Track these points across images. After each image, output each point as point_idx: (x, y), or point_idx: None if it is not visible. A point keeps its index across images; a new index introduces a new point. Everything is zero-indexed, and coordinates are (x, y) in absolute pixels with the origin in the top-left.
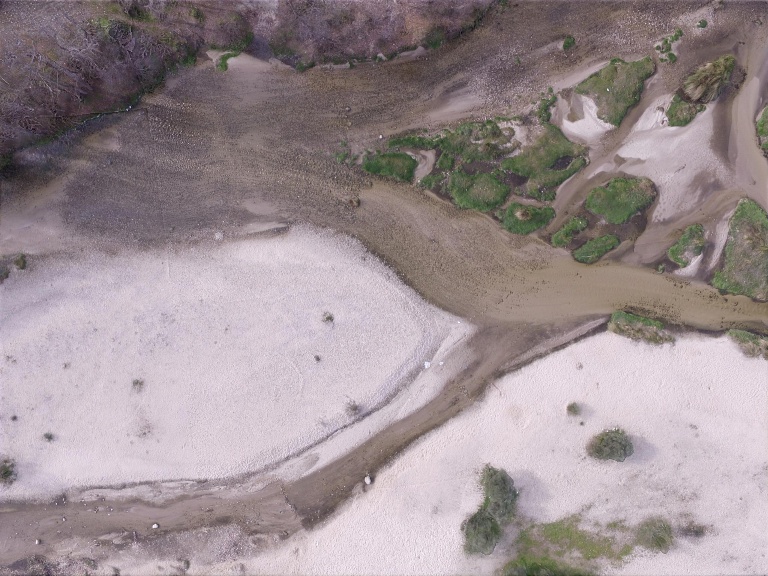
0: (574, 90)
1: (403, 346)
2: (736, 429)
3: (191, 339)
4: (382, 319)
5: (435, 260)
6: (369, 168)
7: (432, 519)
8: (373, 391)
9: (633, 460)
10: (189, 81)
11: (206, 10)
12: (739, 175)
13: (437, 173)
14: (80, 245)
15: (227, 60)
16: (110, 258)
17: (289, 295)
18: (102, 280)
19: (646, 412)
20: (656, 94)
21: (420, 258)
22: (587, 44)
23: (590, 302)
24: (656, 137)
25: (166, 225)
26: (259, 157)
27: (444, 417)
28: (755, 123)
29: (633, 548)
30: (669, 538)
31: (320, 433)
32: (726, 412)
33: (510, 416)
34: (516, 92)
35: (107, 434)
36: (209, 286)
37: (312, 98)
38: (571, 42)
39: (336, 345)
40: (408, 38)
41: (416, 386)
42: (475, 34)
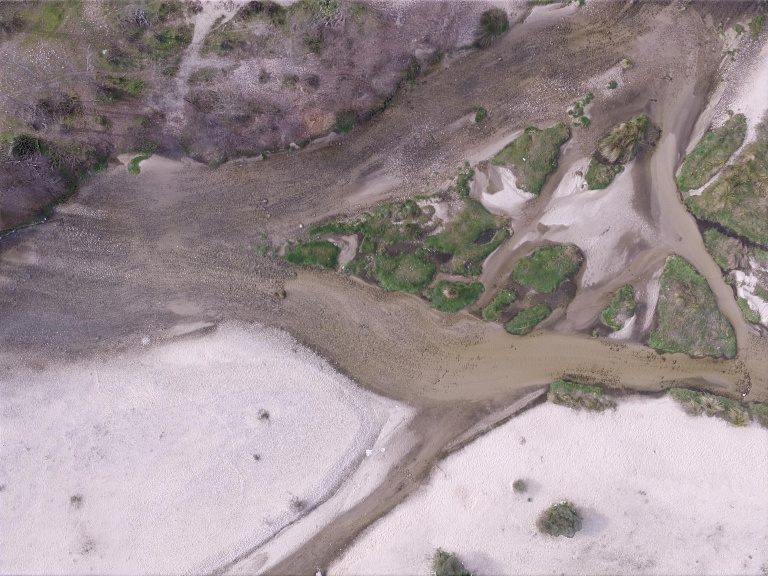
0: (491, 162)
1: (342, 437)
2: (685, 491)
3: (126, 450)
4: (318, 411)
5: (367, 345)
6: (292, 259)
7: None
8: (316, 485)
9: (584, 532)
10: (102, 188)
11: (112, 116)
12: (664, 232)
13: (361, 258)
14: (6, 363)
15: (139, 163)
16: (38, 374)
17: (222, 395)
18: (31, 397)
19: (593, 482)
20: (573, 159)
21: (352, 345)
22: (499, 115)
23: (527, 374)
24: (577, 202)
25: (92, 335)
26: (180, 257)
27: (391, 504)
28: (675, 179)
29: None
30: None
31: (266, 532)
32: (673, 475)
33: (457, 498)
34: (433, 169)
35: (49, 554)
36: (140, 394)
37: (228, 193)
38: (483, 114)
39: (274, 442)
40: (319, 125)
41: (359, 475)
42: (386, 115)
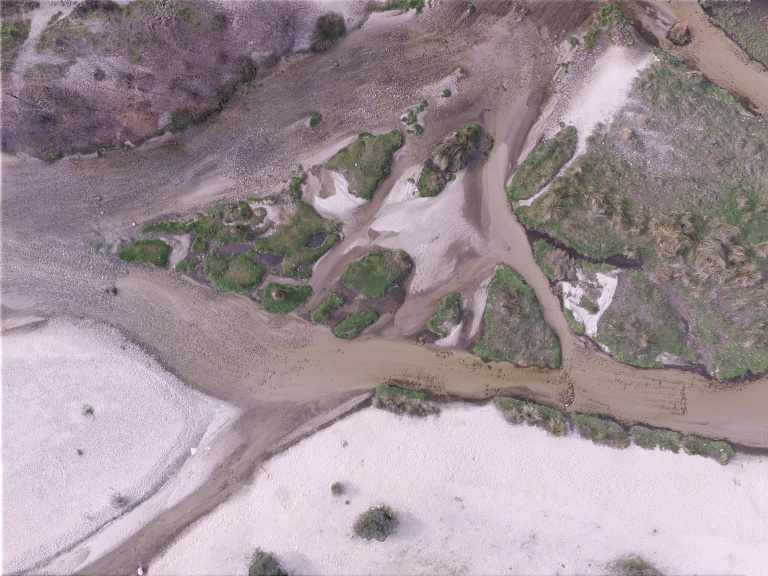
0: (324, 166)
1: (165, 434)
2: (501, 499)
3: None
4: (143, 408)
5: (196, 345)
6: (123, 257)
7: None
8: (138, 482)
9: (401, 536)
10: None
11: None
12: (493, 242)
13: (192, 257)
14: None
15: None
16: None
17: (48, 390)
18: None
19: (411, 487)
20: (405, 166)
21: (181, 344)
22: (334, 119)
23: (354, 377)
24: (408, 209)
25: None
26: (13, 252)
27: (214, 502)
28: (506, 189)
29: None
30: None
31: (88, 527)
32: (490, 482)
33: (278, 498)
34: (267, 171)
35: None
36: None
37: (63, 189)
38: (317, 119)
39: (98, 438)
40: (154, 124)
41: (184, 473)
42: (222, 116)
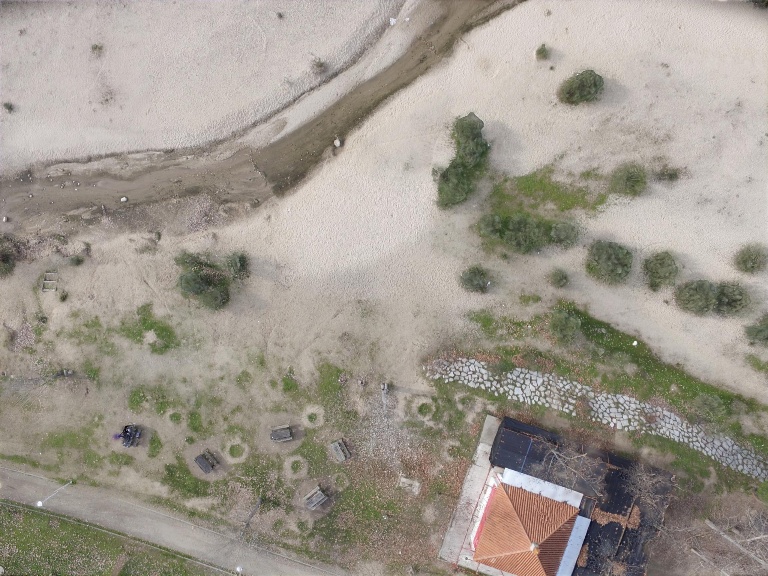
0: None
1: None
2: (708, 65)
3: None
4: None
5: None
6: None
7: (403, 176)
8: (338, 48)
9: (604, 103)
10: None
11: None
12: None
13: None
14: None
15: None
16: None
17: None
18: None
19: (616, 53)
20: None
21: None
22: None
23: None
24: None
25: None
26: None
27: (412, 76)
28: None
29: (607, 196)
30: (642, 173)
31: (286, 95)
32: (697, 49)
33: (479, 68)
34: None
35: (69, 103)
36: None
37: None
38: None
39: (298, 1)
40: None
41: (382, 44)
42: None
